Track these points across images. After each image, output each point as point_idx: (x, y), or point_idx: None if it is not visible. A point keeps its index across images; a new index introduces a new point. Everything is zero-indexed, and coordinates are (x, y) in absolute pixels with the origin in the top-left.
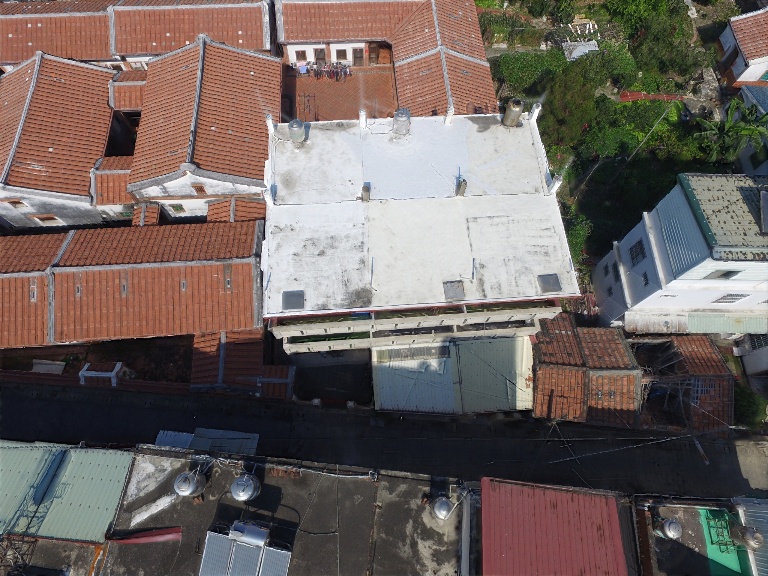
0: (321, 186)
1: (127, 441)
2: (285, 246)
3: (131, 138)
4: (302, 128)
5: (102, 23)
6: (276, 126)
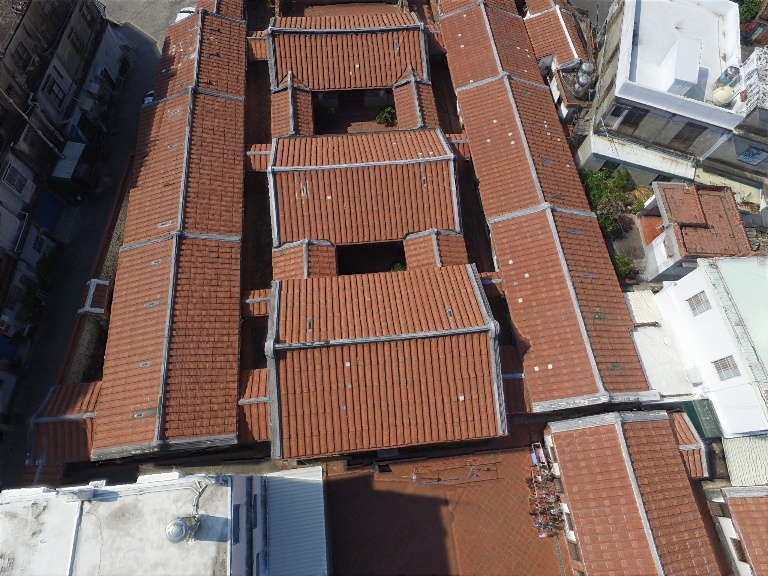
0: (104, 573)
1: (47, 329)
2: (8, 527)
3: (398, 259)
4: (172, 541)
5: (529, 200)
6: (227, 484)
